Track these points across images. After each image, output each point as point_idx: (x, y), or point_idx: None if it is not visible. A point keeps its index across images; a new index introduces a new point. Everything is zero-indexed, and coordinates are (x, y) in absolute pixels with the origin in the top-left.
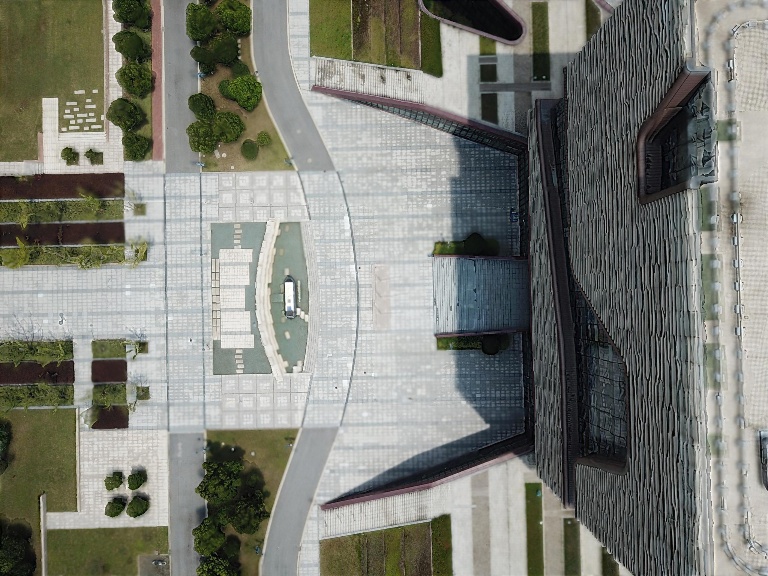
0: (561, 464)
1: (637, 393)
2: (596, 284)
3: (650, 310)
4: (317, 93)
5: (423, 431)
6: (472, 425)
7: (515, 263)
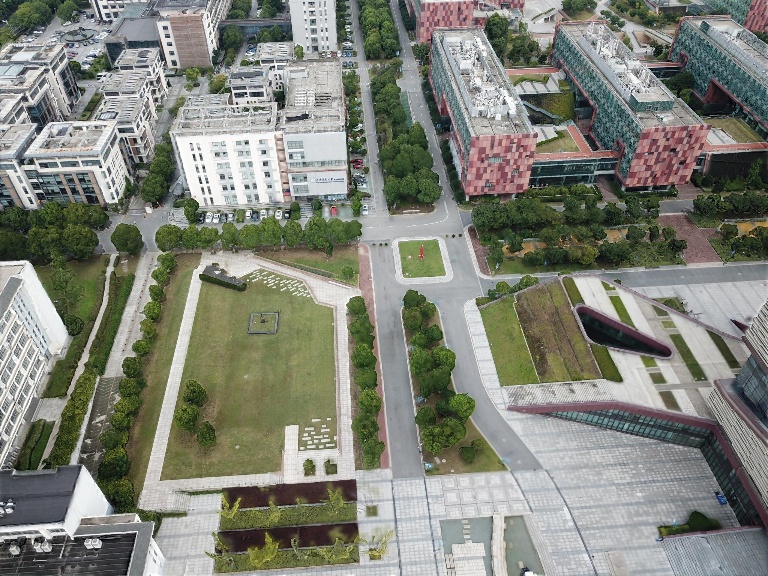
0: None
1: None
2: None
3: None
4: (513, 411)
5: None
6: None
7: (749, 534)
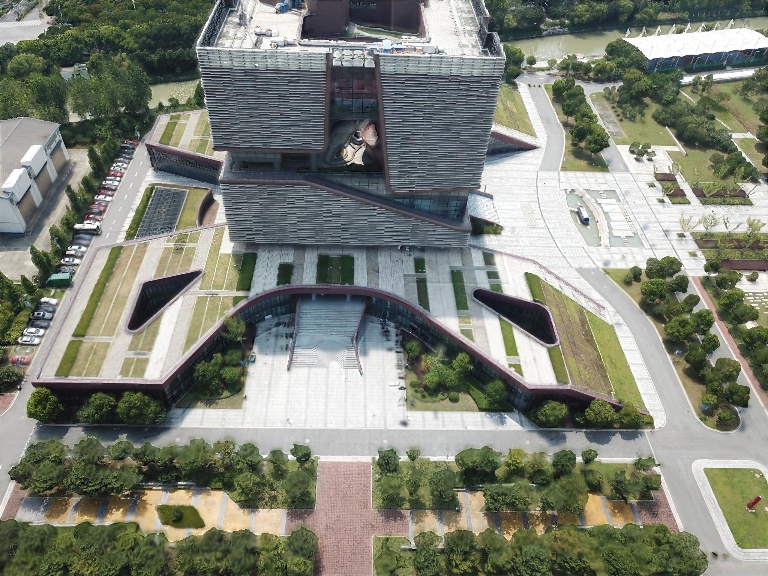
0: None
1: None
2: None
3: None
4: None
5: (492, 168)
6: None
7: None
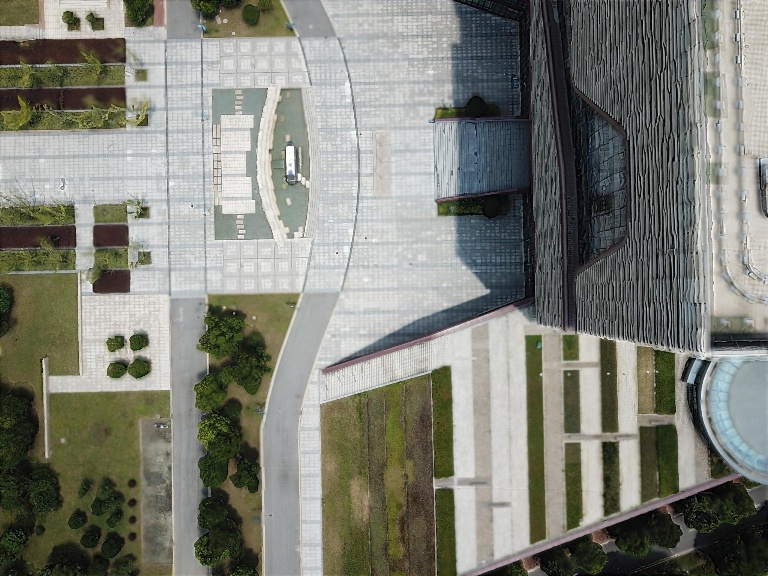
0: (561, 290)
1: (637, 150)
2: (597, 78)
3: (651, 56)
4: None
5: (424, 296)
6: (472, 290)
7: (516, 123)
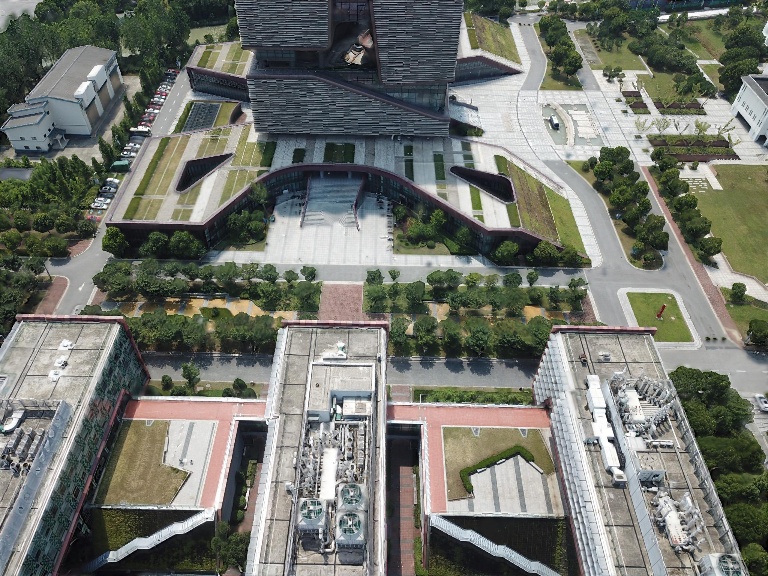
0: None
1: None
2: None
3: None
4: None
5: (480, 88)
6: None
7: None
